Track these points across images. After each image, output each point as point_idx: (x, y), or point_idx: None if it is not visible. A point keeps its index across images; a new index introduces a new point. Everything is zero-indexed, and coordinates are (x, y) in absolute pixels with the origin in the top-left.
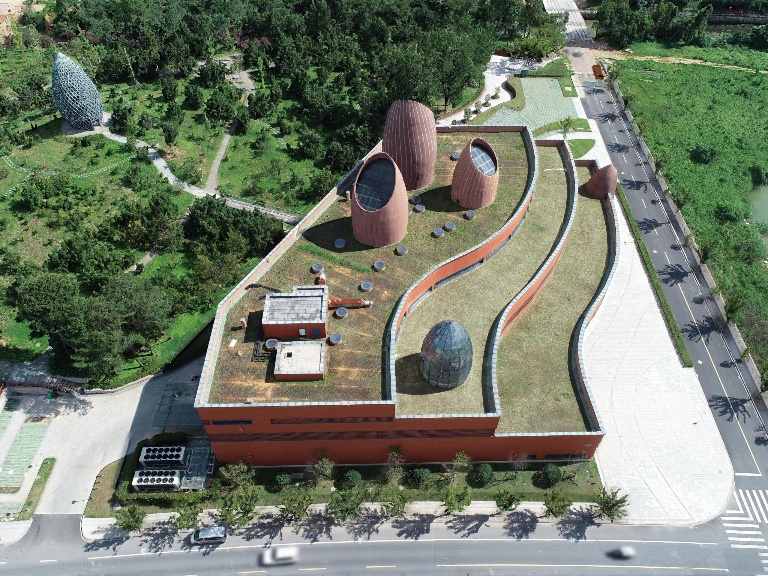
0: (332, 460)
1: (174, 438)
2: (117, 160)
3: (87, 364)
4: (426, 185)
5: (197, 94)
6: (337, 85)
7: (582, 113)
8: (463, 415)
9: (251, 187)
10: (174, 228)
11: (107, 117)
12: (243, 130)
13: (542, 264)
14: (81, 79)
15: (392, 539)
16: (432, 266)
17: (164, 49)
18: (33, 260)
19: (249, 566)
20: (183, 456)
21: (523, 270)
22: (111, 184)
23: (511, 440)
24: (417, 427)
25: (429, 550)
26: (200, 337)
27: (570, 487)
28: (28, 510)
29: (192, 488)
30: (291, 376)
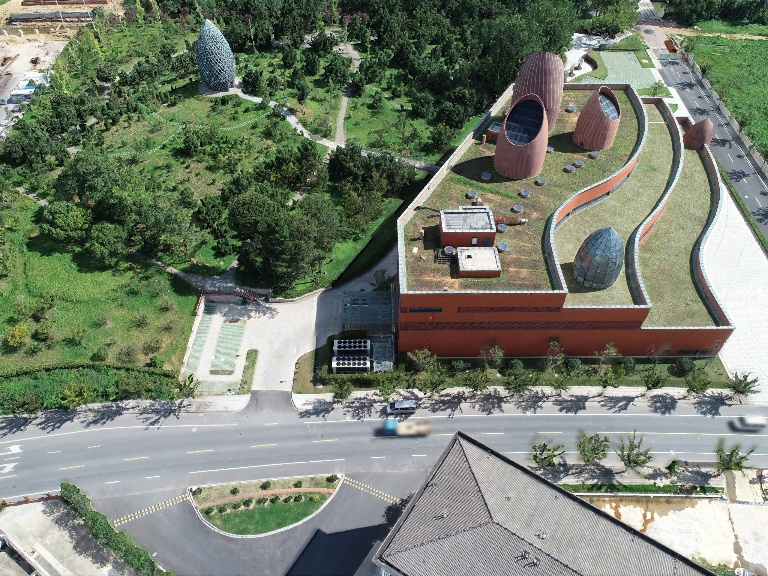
0: (501, 348)
1: (358, 334)
2: (254, 116)
3: (286, 269)
4: (550, 132)
5: (316, 61)
6: (434, 56)
7: (662, 82)
8: (620, 306)
9: (378, 139)
10: (323, 170)
11: (237, 80)
12: (359, 93)
13: (661, 197)
14: (223, 44)
15: (555, 413)
16: (570, 194)
17: (282, 21)
18: (201, 196)
19: (439, 430)
20: (370, 347)
21: (645, 201)
22: (253, 136)
23: (653, 333)
24: (578, 318)
25: (588, 421)
26: (357, 260)
27: (701, 376)
28: (245, 387)
29: (384, 370)
30: (474, 273)
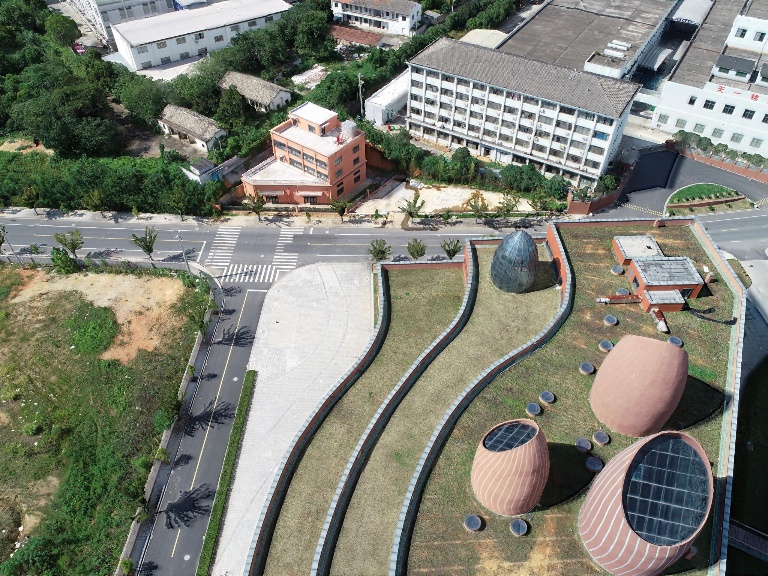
0: None
1: None
2: None
3: None
4: None
5: None
6: None
7: None
8: (495, 238)
9: None
10: None
11: None
12: None
13: (407, 393)
14: None
15: None
16: (545, 351)
17: None
18: None
19: None
20: None
21: (431, 384)
22: None
23: None
24: None
25: None
26: None
27: None
28: None
29: None
30: None
